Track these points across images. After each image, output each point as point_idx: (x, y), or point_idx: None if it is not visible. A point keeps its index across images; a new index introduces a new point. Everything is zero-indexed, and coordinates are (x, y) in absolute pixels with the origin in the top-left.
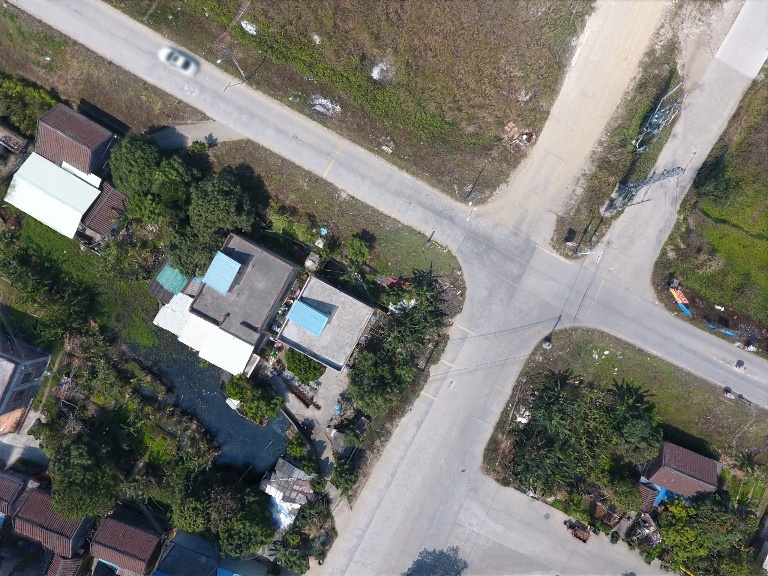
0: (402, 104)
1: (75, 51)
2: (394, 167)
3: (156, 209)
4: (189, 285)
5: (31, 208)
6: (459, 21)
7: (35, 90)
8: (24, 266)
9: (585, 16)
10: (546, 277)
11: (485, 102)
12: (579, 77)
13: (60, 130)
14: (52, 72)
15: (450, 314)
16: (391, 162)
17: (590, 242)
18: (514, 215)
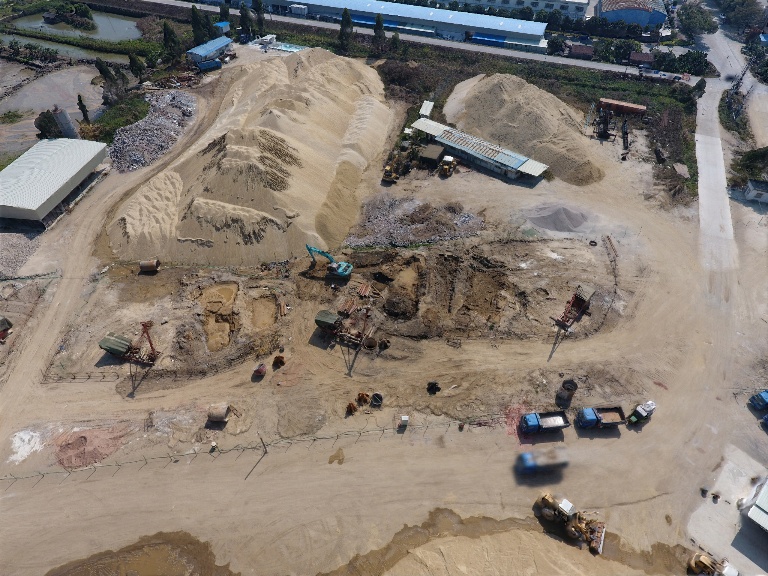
0: None
1: None
2: None
3: None
4: None
5: None
6: None
7: None
8: None
9: None
10: None
11: None
12: None
13: None
14: None
15: None
16: None
17: None
18: None
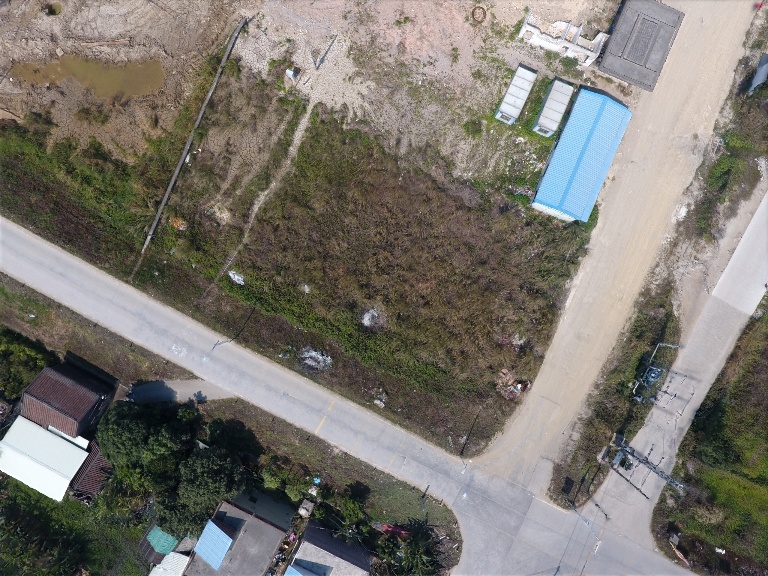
0: (394, 353)
1: (60, 313)
2: (387, 421)
3: (145, 481)
4: (181, 543)
5: (18, 473)
6: (451, 266)
7: (20, 346)
8: (13, 516)
9: (579, 257)
10: (544, 528)
11: (478, 355)
12: (574, 319)
13: (46, 402)
14: (37, 326)
15: (447, 566)
16: (384, 416)
17: (588, 493)
18: (510, 465)
